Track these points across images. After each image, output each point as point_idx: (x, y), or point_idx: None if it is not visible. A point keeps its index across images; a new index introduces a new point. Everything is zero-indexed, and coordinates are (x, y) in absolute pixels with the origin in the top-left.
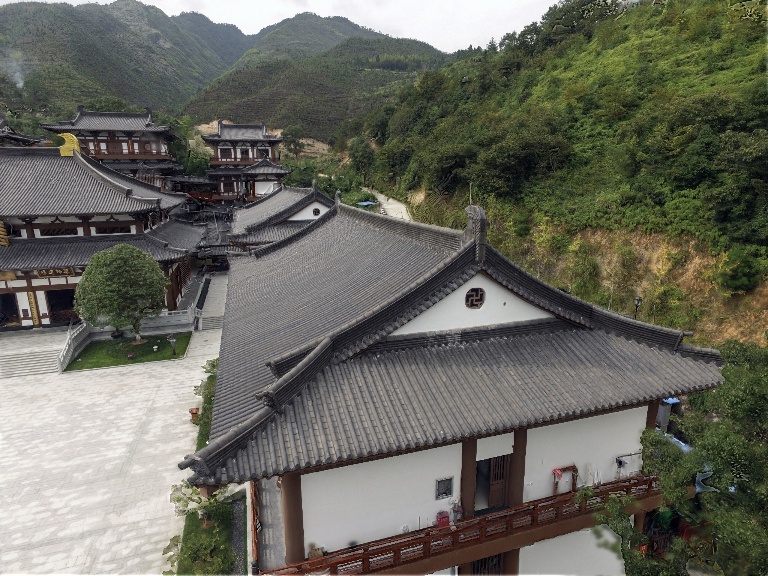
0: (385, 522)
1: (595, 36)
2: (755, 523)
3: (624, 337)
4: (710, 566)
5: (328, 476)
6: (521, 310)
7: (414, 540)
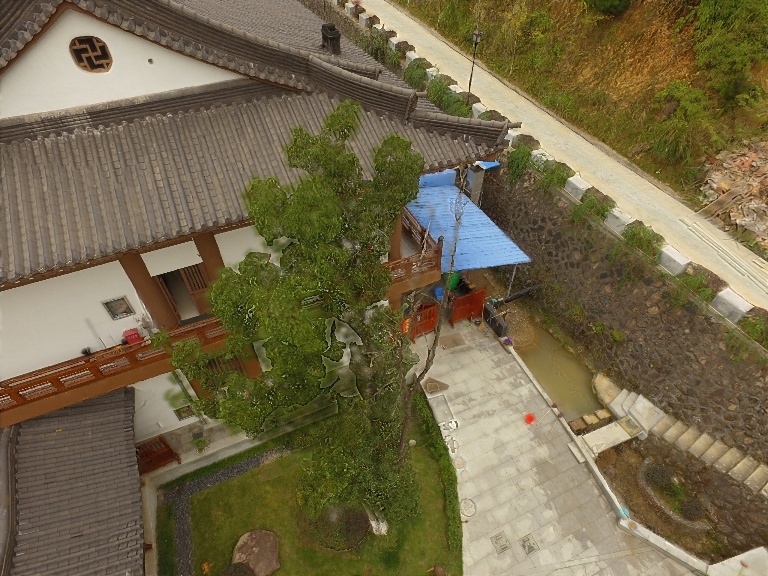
0: (52, 349)
1: None
2: (246, 396)
3: (349, 102)
4: (476, 326)
5: None
6: (186, 70)
7: (72, 368)
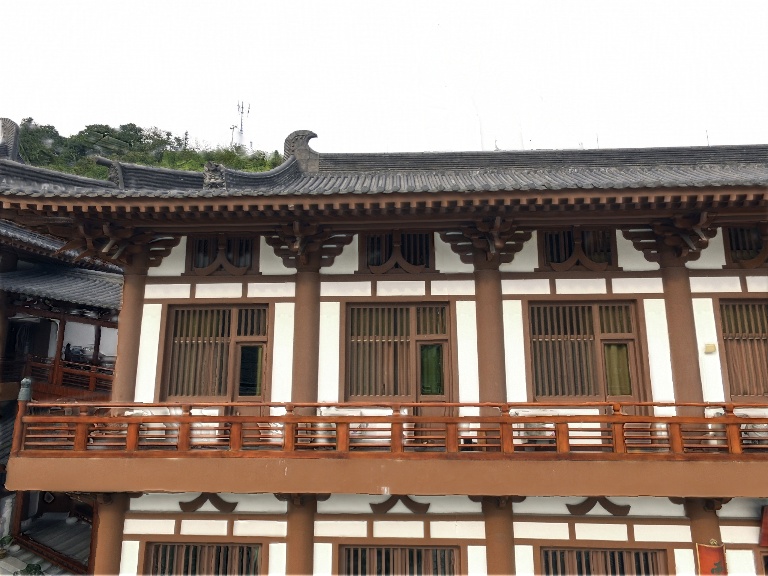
0: None
1: (177, 160)
2: None
3: None
4: None
5: None
6: None
7: None
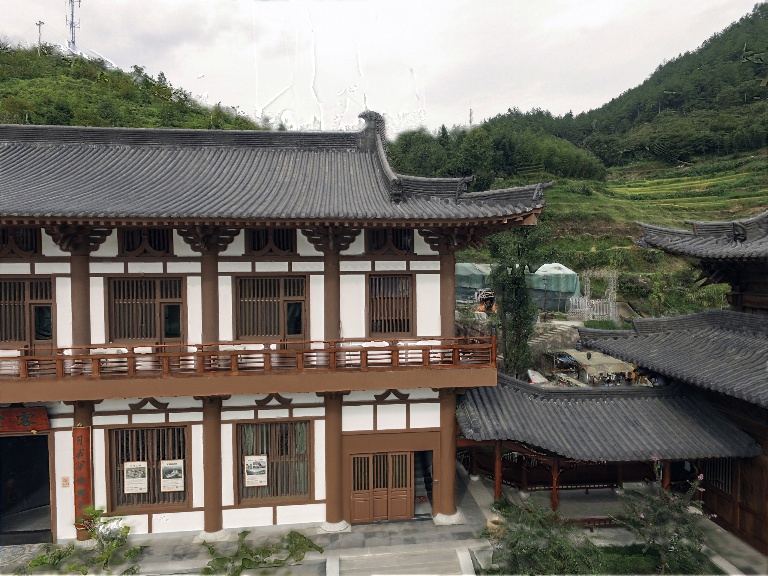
0: None
1: None
2: None
3: None
4: None
5: None
6: None
7: None
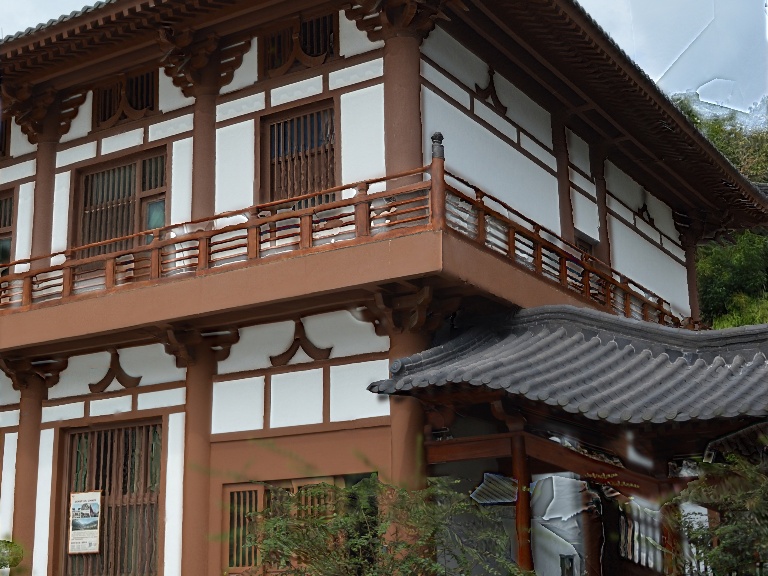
0: None
1: None
2: None
3: None
4: None
5: (446, 112)
6: None
7: None
